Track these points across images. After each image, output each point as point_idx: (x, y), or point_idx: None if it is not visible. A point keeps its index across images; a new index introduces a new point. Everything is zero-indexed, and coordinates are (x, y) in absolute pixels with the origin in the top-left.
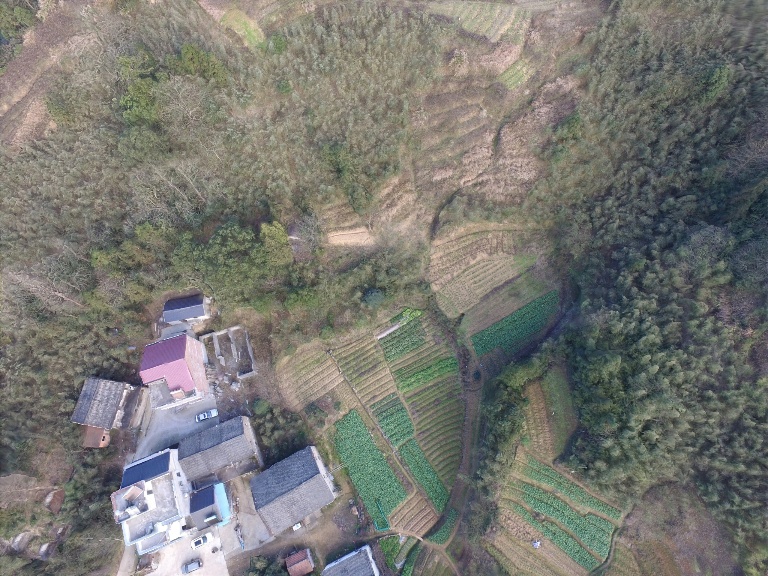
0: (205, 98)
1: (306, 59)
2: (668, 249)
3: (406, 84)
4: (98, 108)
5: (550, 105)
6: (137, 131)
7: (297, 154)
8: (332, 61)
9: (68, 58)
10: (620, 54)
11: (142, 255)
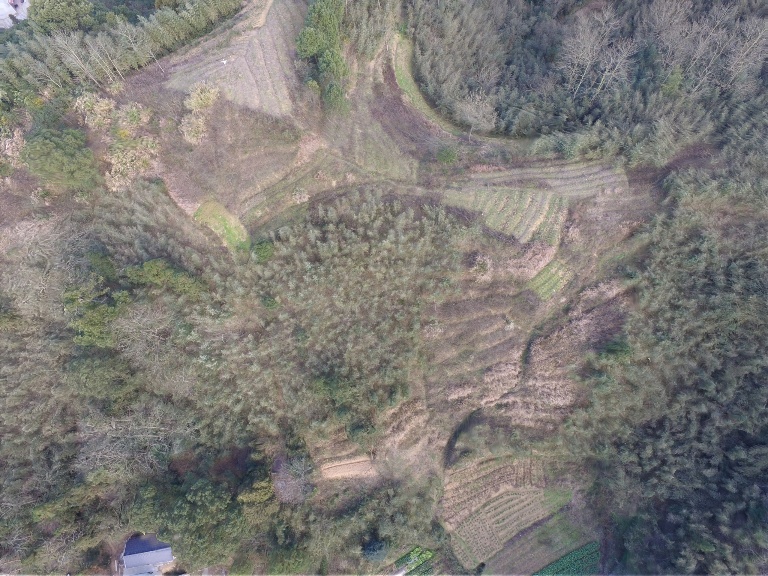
0: (173, 321)
1: (297, 267)
2: (740, 525)
3: (417, 289)
4: (49, 310)
5: (590, 314)
6: (89, 367)
7: (285, 382)
8: (328, 270)
9: (14, 249)
10: (678, 262)
11: (99, 491)
